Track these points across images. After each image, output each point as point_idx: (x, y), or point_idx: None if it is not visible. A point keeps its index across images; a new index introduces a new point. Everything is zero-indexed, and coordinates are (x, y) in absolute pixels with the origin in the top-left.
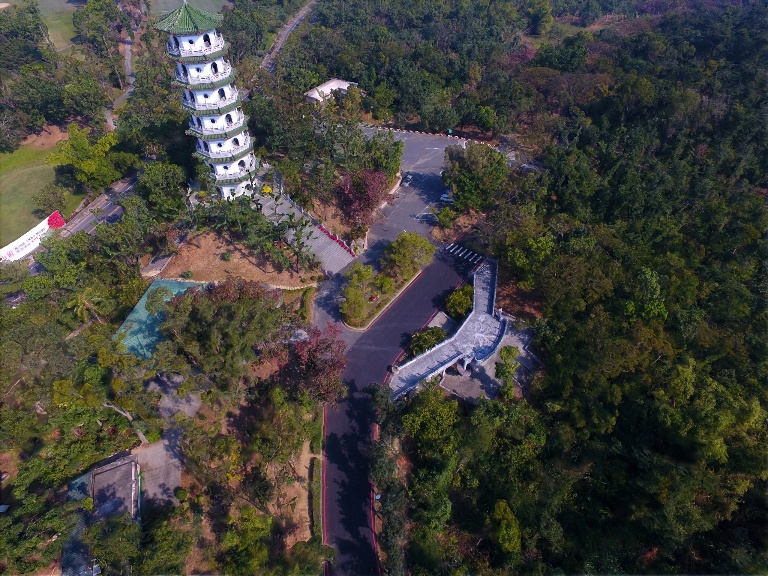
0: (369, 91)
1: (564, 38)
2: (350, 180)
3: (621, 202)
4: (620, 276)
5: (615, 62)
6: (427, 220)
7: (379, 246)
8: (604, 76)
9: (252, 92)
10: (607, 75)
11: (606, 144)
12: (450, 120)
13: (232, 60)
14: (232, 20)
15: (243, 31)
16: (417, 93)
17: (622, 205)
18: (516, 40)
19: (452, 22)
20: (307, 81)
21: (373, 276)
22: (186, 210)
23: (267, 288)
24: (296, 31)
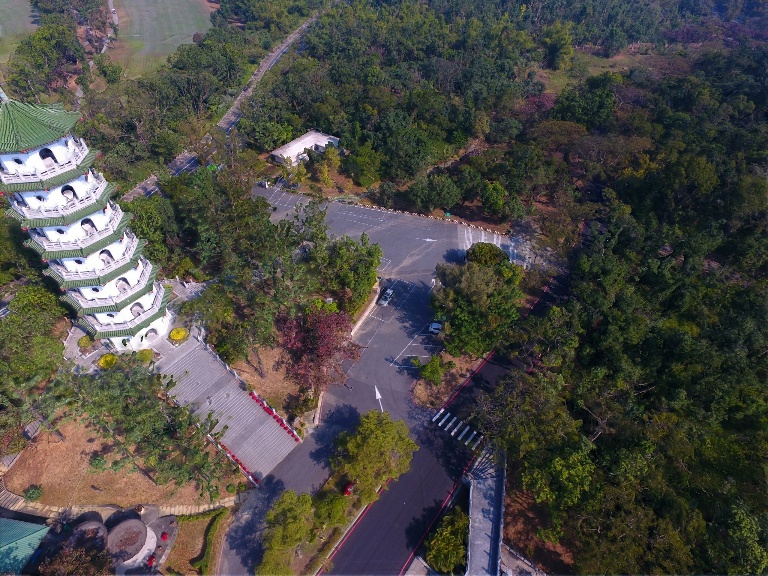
0: (352, 150)
1: (587, 77)
2: (299, 319)
3: (684, 358)
4: (700, 527)
5: (652, 115)
6: (409, 368)
7: (337, 418)
8: (643, 141)
9: (201, 157)
10: (647, 140)
11: (658, 262)
12: (448, 199)
13: (191, 106)
14: (197, 55)
15: (210, 68)
16: (410, 155)
17: (684, 360)
18: (531, 76)
19: (458, 54)
20: (276, 137)
21: (321, 481)
22: (25, 406)
23: (144, 534)
24: (275, 67)
